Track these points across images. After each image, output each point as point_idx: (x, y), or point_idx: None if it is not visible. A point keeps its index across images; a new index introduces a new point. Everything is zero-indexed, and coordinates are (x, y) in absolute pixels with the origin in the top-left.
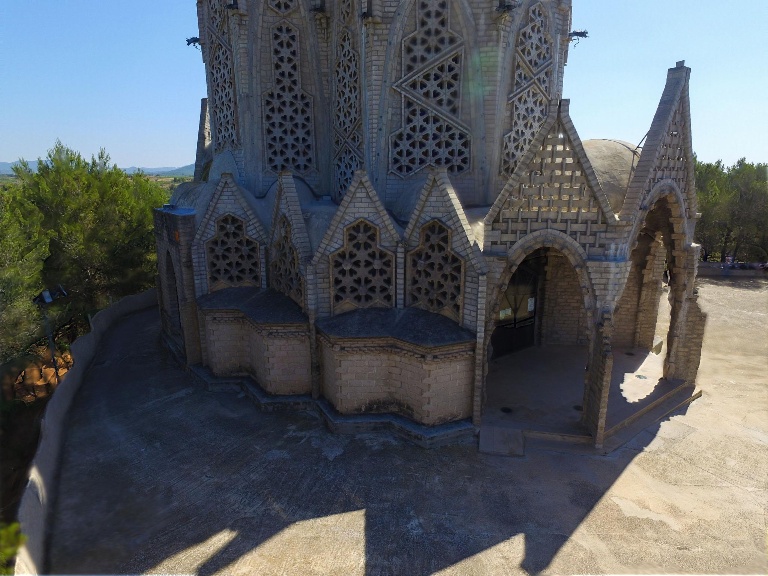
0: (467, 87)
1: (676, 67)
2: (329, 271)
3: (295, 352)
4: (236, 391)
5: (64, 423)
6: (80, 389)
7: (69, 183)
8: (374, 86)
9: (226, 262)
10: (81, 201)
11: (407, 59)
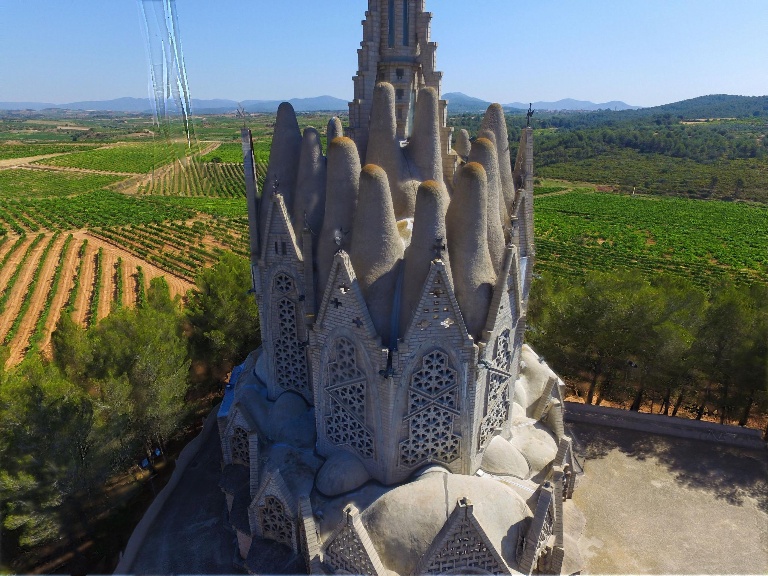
0: (370, 406)
1: (458, 502)
2: (259, 515)
3: (250, 542)
4: (235, 534)
5: (148, 530)
6: (173, 493)
7: (221, 296)
8: (314, 383)
9: (241, 450)
10: (226, 309)
11: (332, 375)
